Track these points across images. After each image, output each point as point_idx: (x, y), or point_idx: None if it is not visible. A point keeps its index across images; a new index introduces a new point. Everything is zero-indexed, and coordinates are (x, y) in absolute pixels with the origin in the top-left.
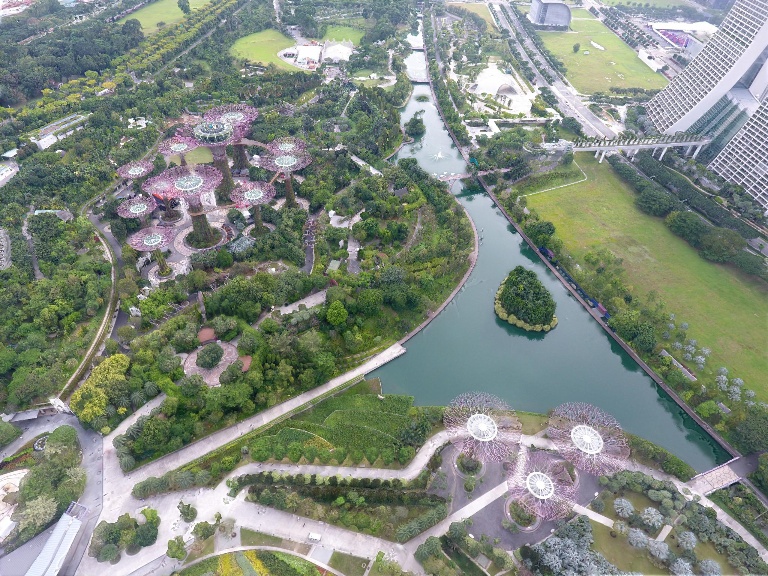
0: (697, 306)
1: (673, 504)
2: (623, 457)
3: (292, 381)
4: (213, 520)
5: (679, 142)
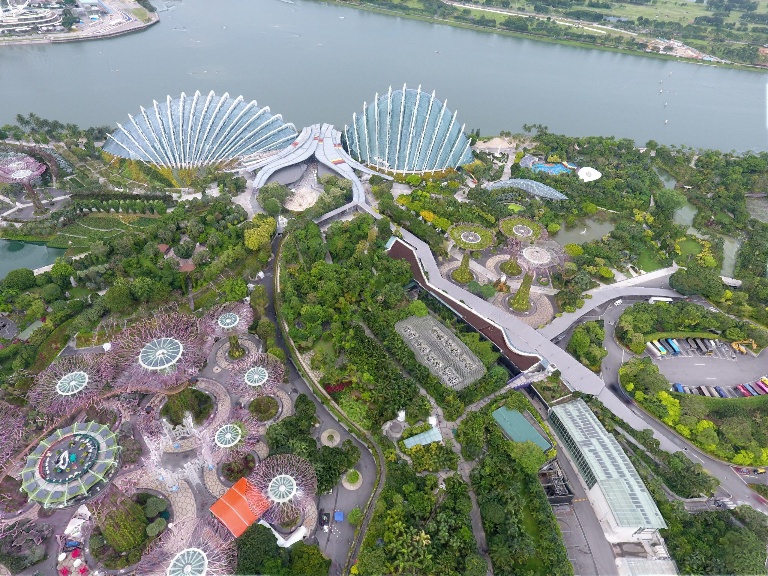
0: None
1: None
2: None
3: None
4: (194, 195)
5: None
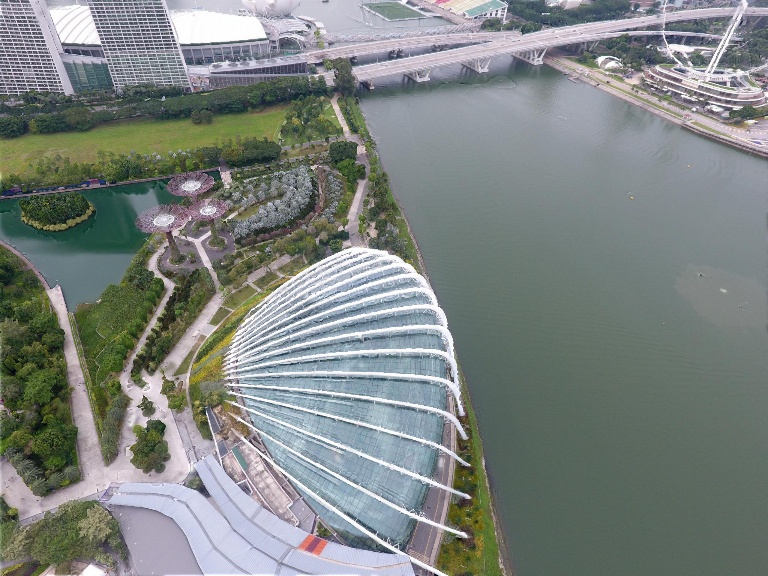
0: (120, 147)
1: (233, 188)
2: (207, 177)
3: (47, 353)
4: (160, 395)
5: None
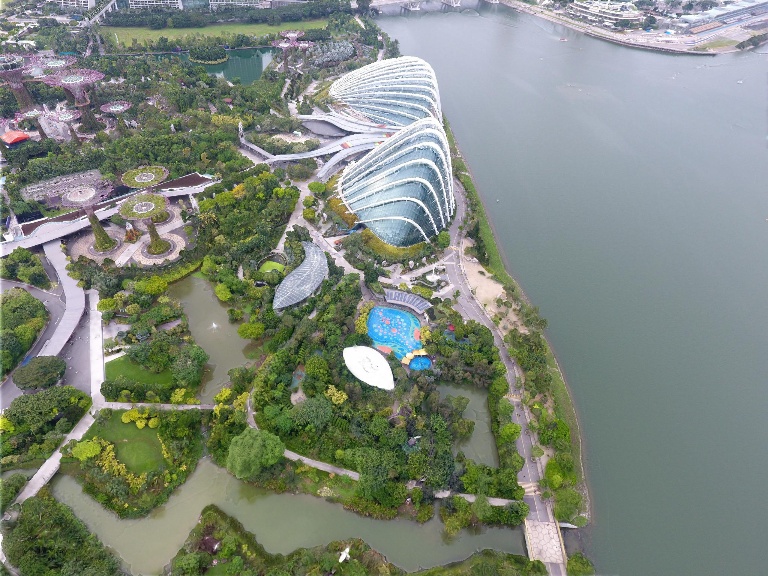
0: None
1: None
2: None
3: None
4: None
5: (110, 2)
